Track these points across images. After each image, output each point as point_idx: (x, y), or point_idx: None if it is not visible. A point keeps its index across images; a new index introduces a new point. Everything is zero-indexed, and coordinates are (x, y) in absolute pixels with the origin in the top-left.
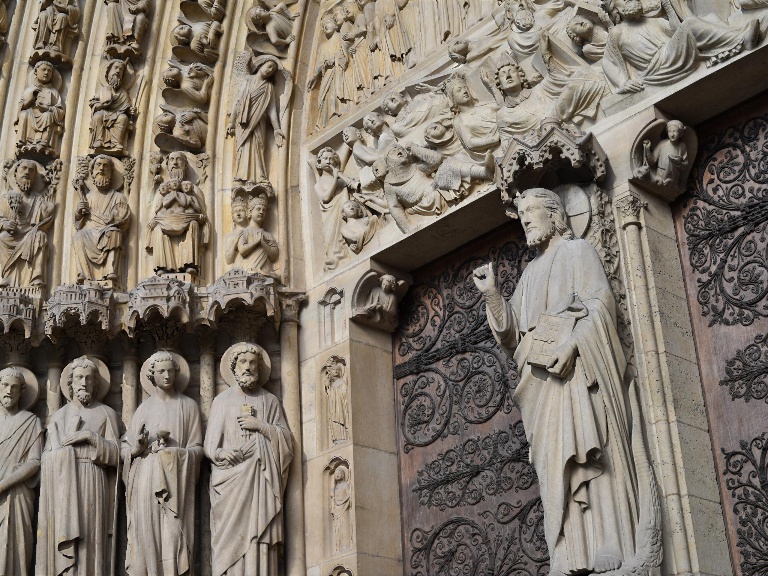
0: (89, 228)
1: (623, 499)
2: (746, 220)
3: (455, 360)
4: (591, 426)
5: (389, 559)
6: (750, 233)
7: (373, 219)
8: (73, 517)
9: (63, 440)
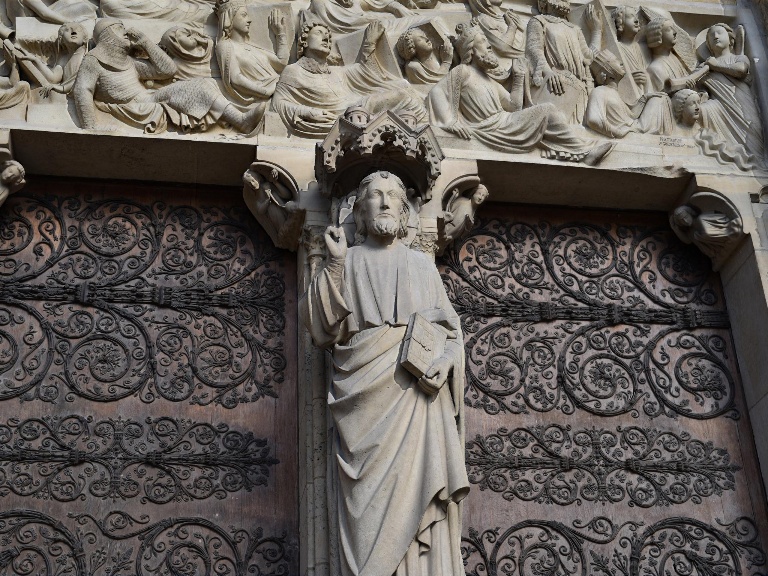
0: None
1: (458, 554)
2: (505, 312)
3: (68, 309)
4: None
5: None
6: (506, 326)
7: (25, 85)
8: None
9: None
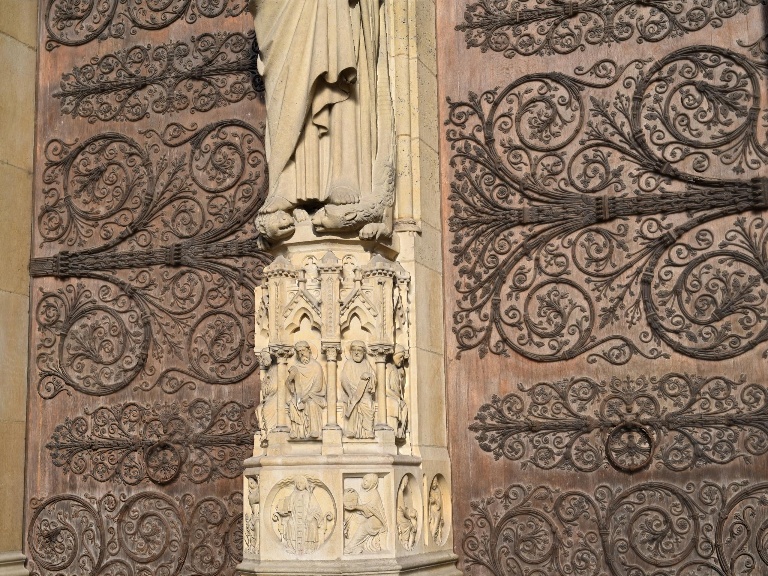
0: None
1: (366, 130)
2: None
3: None
4: (350, 42)
5: (19, 169)
6: None
7: None
8: None
9: None
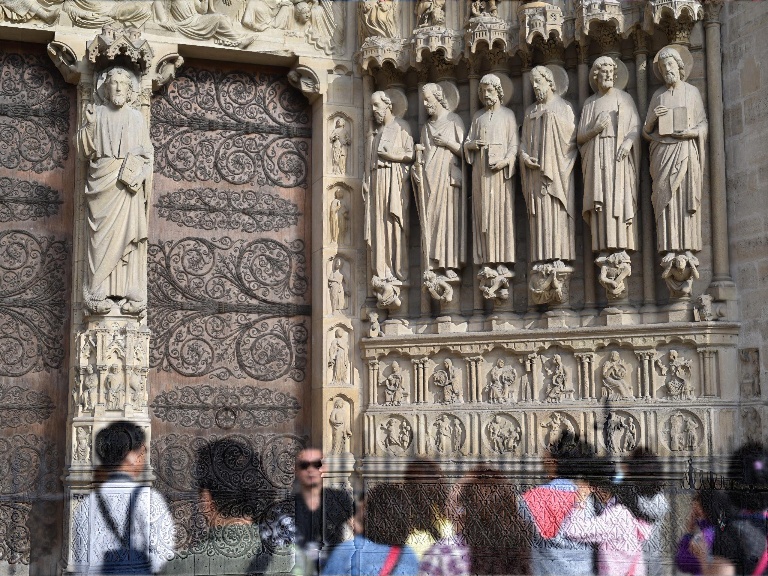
0: None
1: None
2: (190, 125)
3: None
4: None
5: None
6: (190, 132)
7: None
8: None
9: None
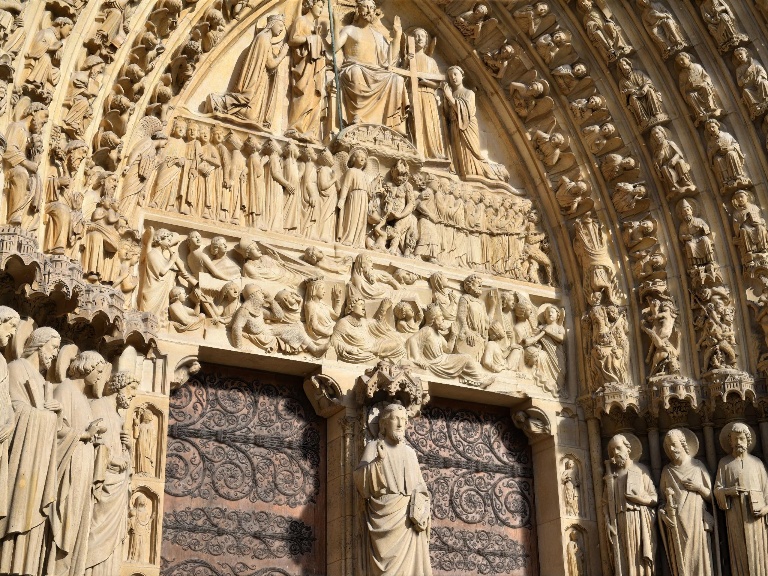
0: (63, 203)
1: None
2: (427, 461)
3: (212, 444)
4: None
5: None
6: (427, 469)
7: None
8: (56, 481)
9: (48, 403)
